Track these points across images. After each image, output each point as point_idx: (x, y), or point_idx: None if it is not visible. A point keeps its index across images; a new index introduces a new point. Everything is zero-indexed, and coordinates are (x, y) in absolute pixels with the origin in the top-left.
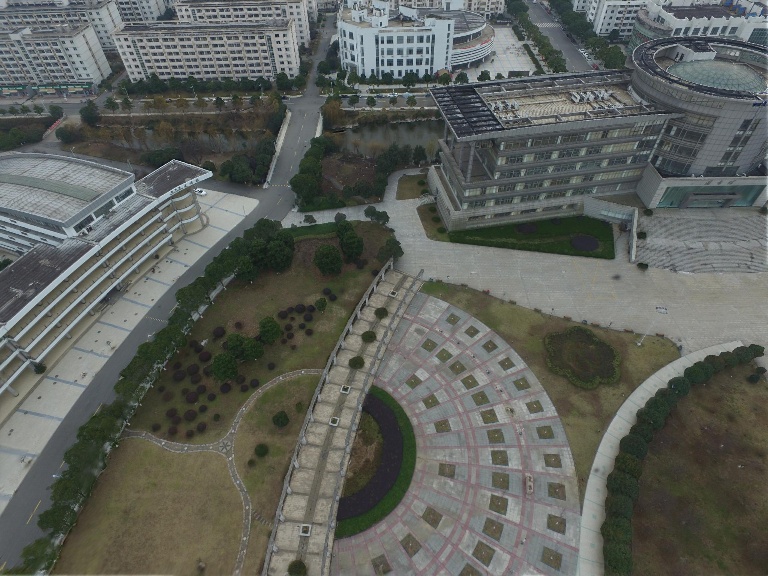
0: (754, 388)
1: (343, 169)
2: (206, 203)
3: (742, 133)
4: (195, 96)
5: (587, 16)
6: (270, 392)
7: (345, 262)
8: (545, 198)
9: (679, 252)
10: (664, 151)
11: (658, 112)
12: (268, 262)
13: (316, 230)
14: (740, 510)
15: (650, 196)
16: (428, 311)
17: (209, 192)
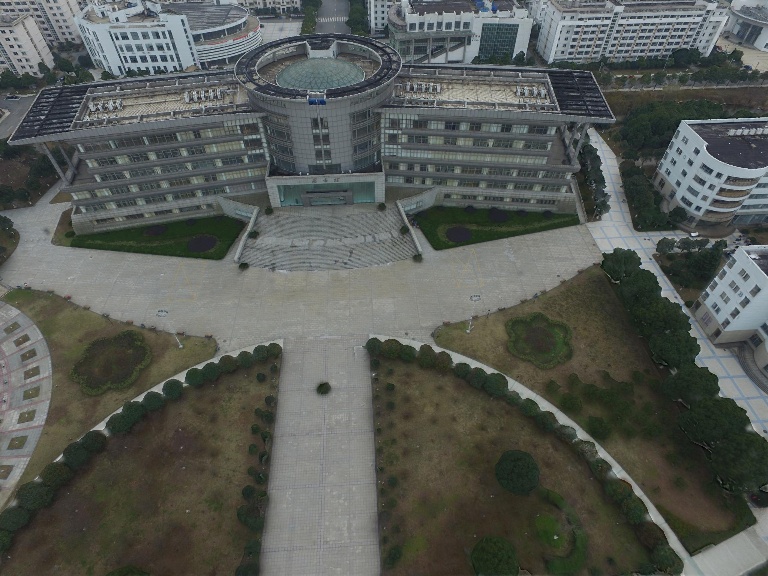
0: (259, 387)
1: (18, 172)
2: None
3: (319, 131)
4: None
5: None
6: None
7: None
8: (174, 199)
9: (282, 251)
10: (272, 150)
11: (243, 111)
12: None
13: None
14: (151, 513)
15: None
16: None
17: None
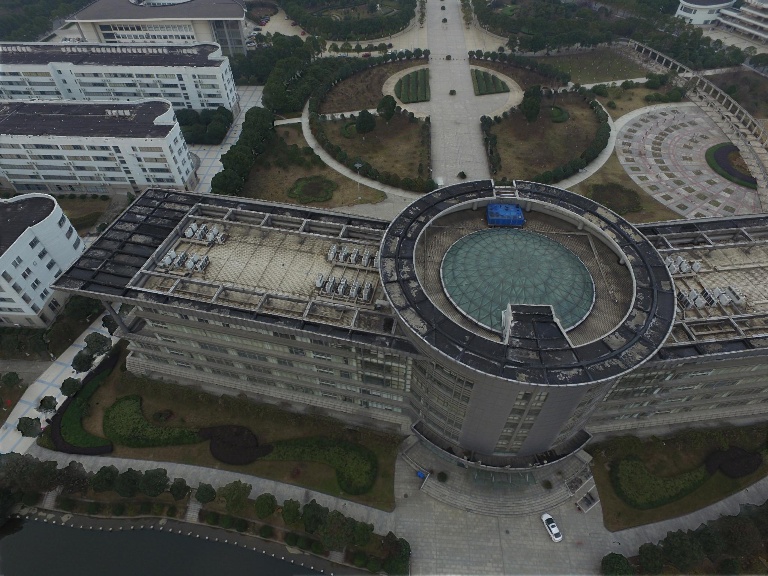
0: None
1: None
2: None
3: None
4: None
5: None
6: None
7: None
8: None
9: None
10: None
11: None
12: None
13: None
14: None
15: None
16: None
17: None
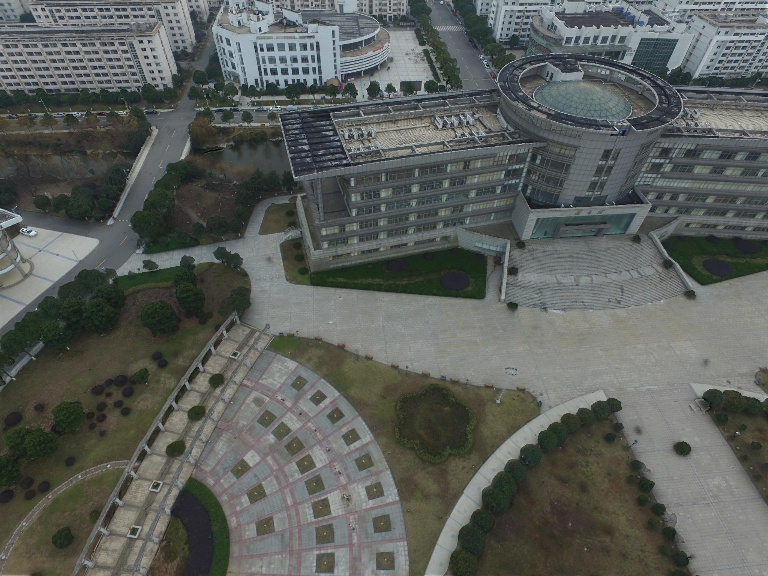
0: (611, 448)
1: (205, 198)
2: (34, 246)
3: (605, 163)
4: (47, 111)
5: (488, 20)
6: (62, 497)
7: (186, 316)
8: (414, 232)
9: (550, 288)
10: (532, 180)
11: (520, 141)
12: (85, 325)
13: (158, 277)
14: None
15: (522, 227)
16: (272, 374)
17: (41, 232)
